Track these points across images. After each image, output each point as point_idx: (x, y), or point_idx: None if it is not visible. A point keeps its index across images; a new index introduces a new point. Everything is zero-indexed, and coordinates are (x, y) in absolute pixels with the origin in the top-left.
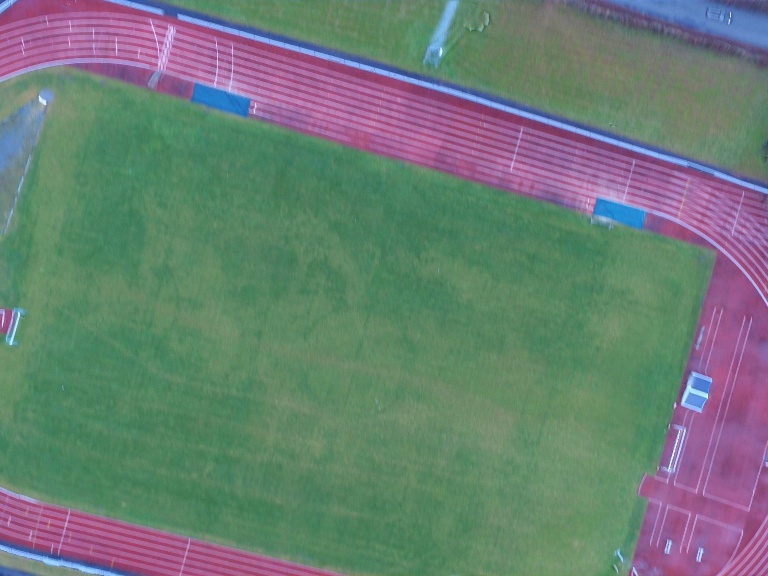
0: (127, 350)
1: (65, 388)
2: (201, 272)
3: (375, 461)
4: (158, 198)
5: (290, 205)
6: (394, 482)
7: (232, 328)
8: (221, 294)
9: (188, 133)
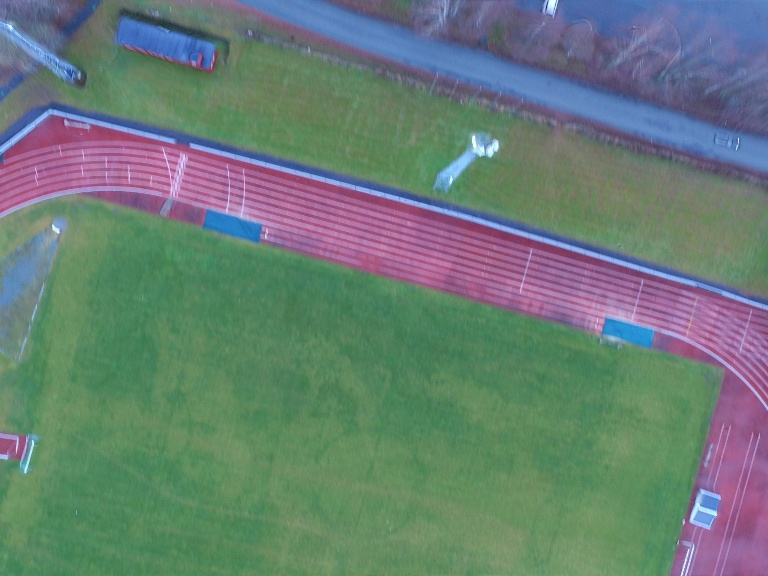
0: (140, 475)
1: (79, 513)
2: (213, 396)
3: None
4: (170, 324)
5: (301, 329)
6: None
7: (244, 452)
8: (233, 418)
9: (200, 259)
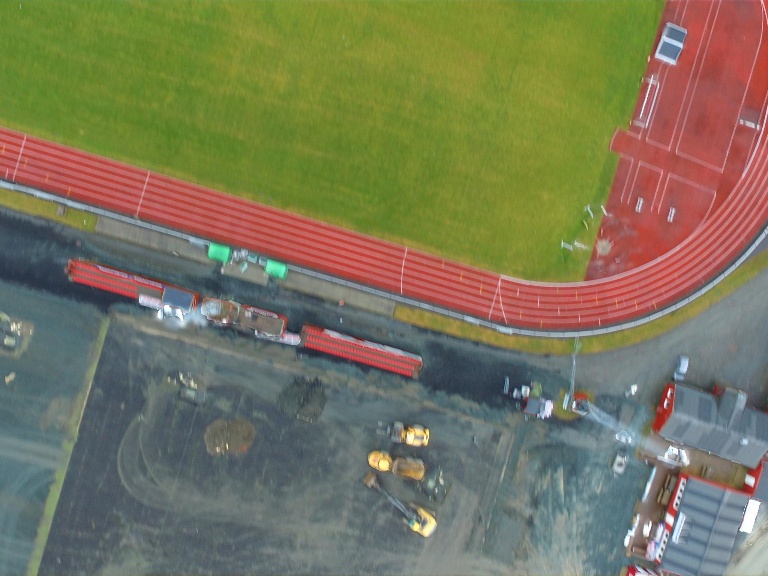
0: None
1: (23, 7)
2: None
3: (341, 100)
4: None
5: None
6: (360, 123)
7: None
8: None
9: None
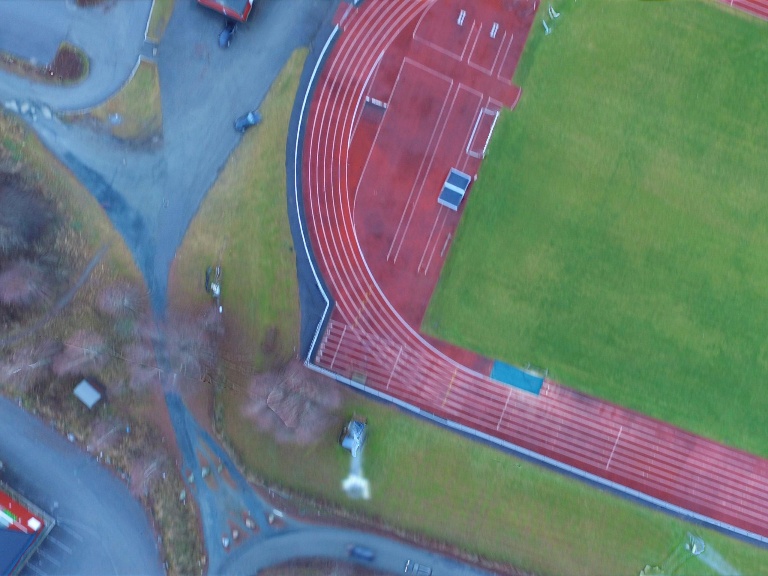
0: None
1: None
2: None
3: None
4: None
5: None
6: (767, 131)
7: None
8: None
9: None
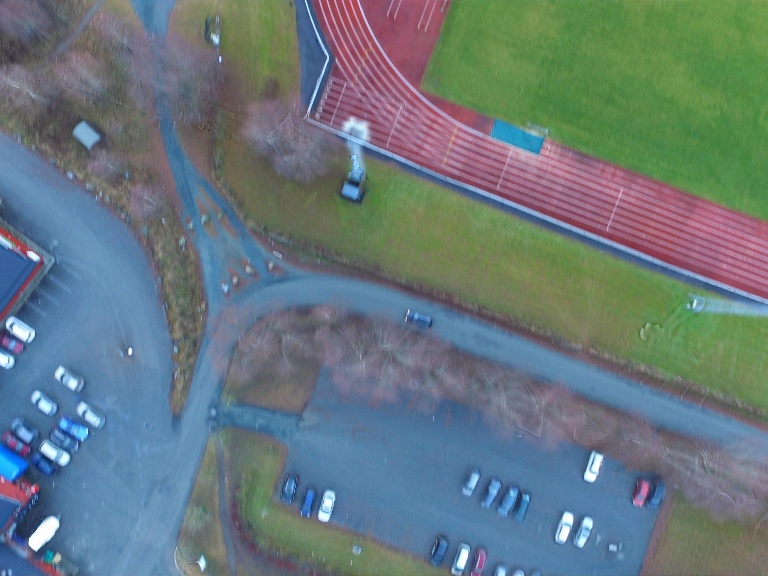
0: None
1: None
2: None
3: None
4: None
5: None
6: None
7: None
8: None
9: None
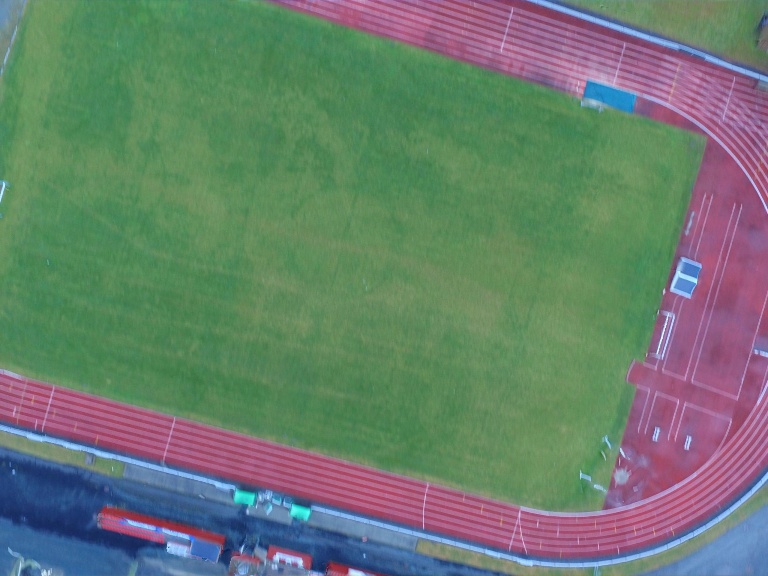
0: (113, 225)
1: (50, 263)
2: (188, 148)
3: (362, 342)
4: (145, 72)
5: (278, 82)
6: (381, 364)
7: (219, 205)
8: (208, 170)
9: (176, 7)
